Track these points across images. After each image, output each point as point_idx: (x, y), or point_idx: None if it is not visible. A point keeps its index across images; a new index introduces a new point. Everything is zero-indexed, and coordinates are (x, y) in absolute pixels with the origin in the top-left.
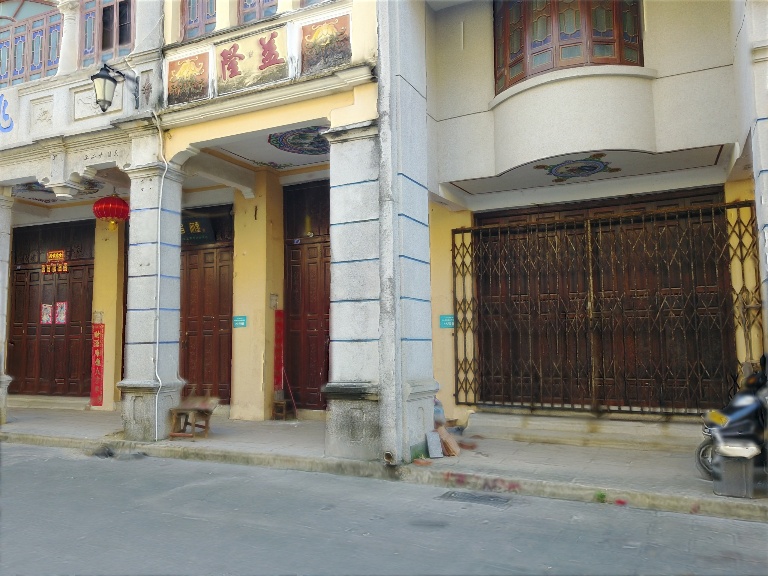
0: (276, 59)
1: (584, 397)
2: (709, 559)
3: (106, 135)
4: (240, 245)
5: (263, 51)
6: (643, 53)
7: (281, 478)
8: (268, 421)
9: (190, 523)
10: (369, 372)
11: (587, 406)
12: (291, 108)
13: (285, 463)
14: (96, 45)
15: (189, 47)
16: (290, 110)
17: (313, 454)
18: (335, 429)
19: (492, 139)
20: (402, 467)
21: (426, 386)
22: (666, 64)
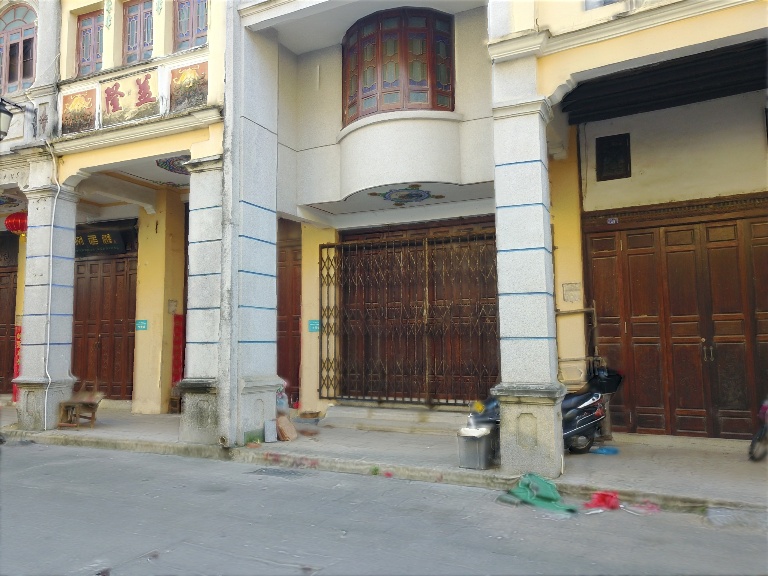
0: (149, 98)
1: (420, 392)
2: (403, 511)
3: (9, 159)
4: (143, 256)
5: (139, 90)
6: (455, 99)
7: (133, 459)
8: (163, 414)
9: (22, 490)
10: (214, 369)
11: (422, 399)
12: (161, 141)
13: (145, 447)
14: (3, 78)
15: (80, 83)
16: (160, 142)
17: (170, 440)
18: (187, 418)
19: (339, 168)
20: (234, 449)
21: (264, 381)
22: (470, 110)
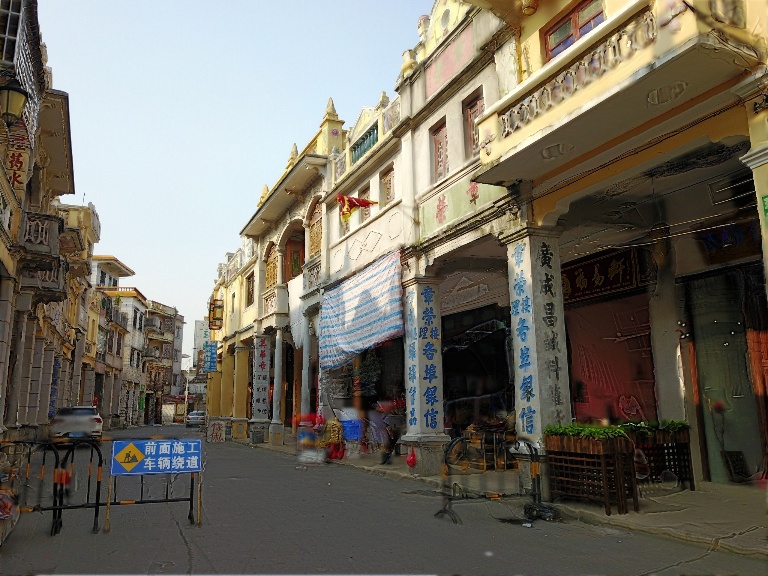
0: None
1: None
2: None
3: None
4: None
5: None
6: None
7: None
8: None
9: None
10: None
11: None
12: None
13: None
14: None
15: None
16: None
17: None
18: None
19: None
20: None
21: None
22: None
